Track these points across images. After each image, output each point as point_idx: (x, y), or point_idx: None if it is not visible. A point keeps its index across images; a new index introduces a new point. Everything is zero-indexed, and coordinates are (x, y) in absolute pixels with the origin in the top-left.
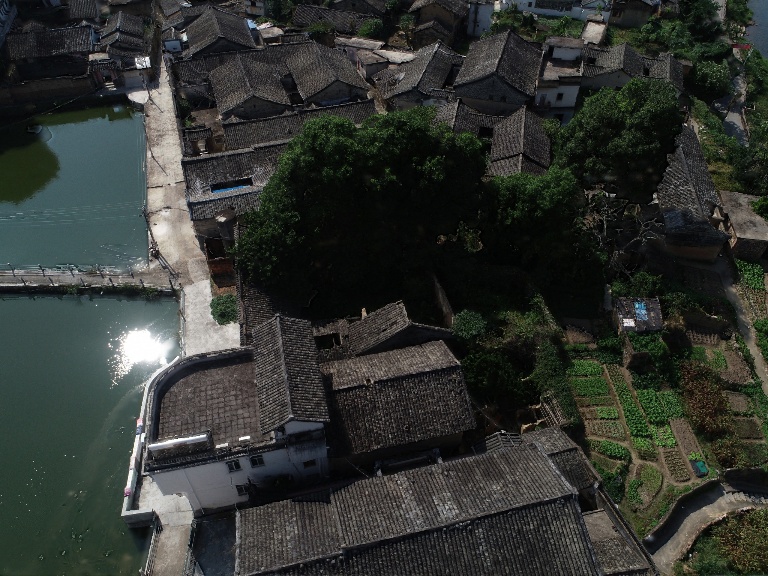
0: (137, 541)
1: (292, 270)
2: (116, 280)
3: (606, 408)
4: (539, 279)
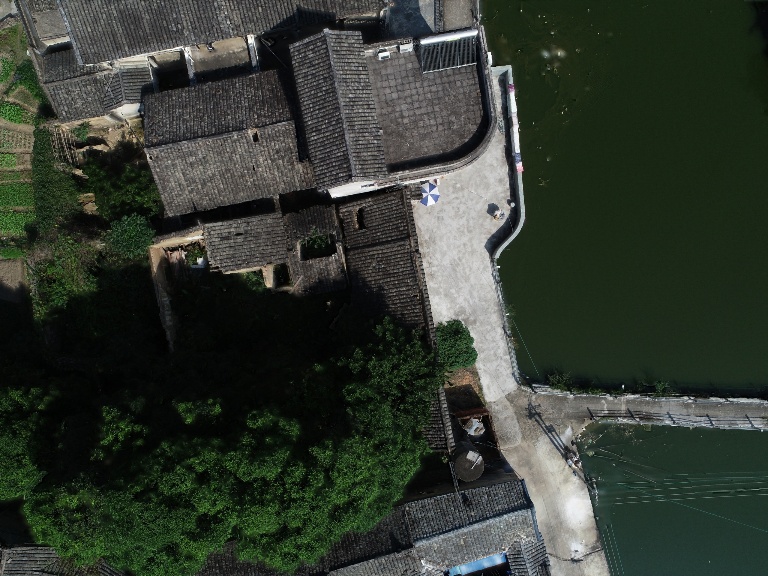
0: (495, 63)
1: (359, 337)
2: (610, 405)
3: (4, 166)
4: (28, 336)
